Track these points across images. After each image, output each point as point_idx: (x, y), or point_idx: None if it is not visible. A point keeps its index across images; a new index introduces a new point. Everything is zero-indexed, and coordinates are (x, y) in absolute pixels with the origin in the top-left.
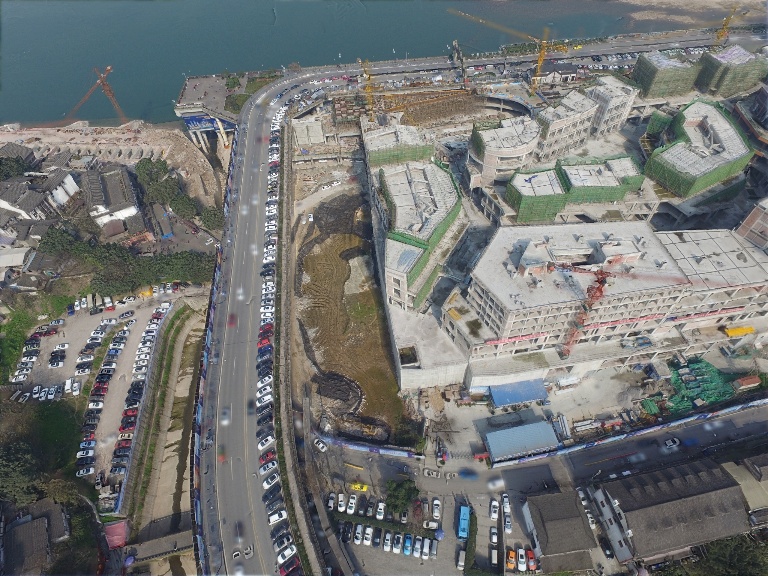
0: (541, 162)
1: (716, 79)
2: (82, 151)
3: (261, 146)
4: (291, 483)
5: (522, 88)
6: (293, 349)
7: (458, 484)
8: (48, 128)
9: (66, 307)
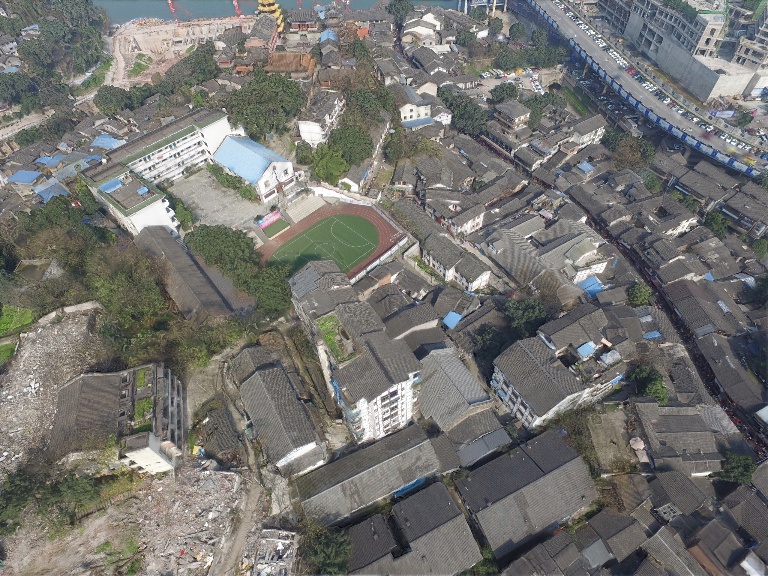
0: None
1: None
2: None
3: (547, 2)
4: None
5: None
6: None
7: (764, 124)
8: None
9: (478, 76)
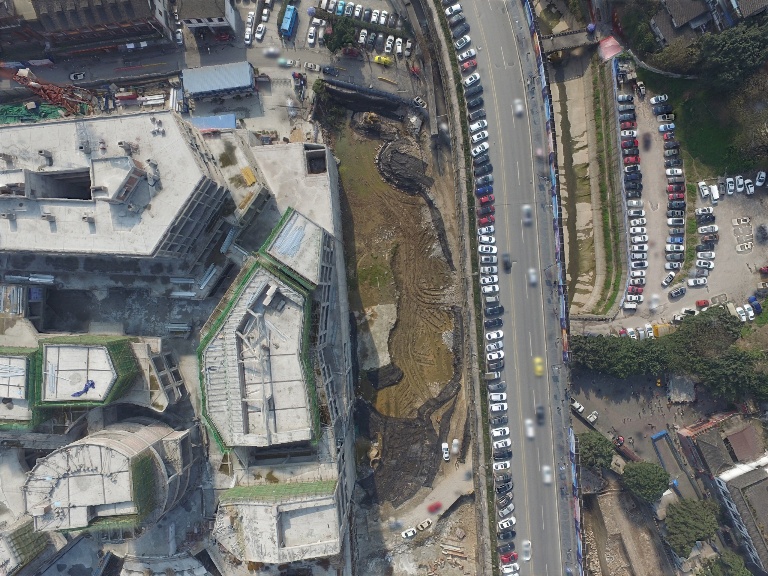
0: None
1: None
2: None
3: None
4: (443, 40)
5: None
6: None
7: (289, 57)
8: None
9: (764, 310)
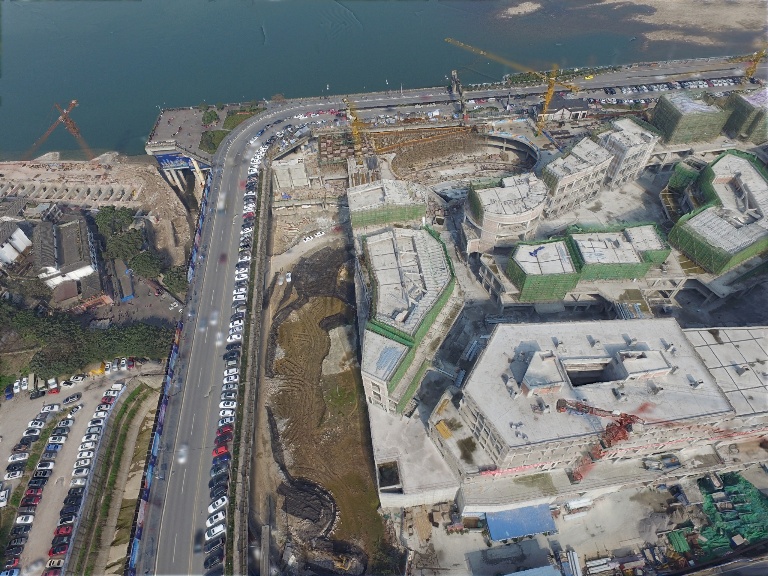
0: (548, 218)
1: (747, 124)
2: (47, 190)
3: (236, 193)
4: None
5: (527, 126)
6: (258, 448)
7: None
8: (14, 161)
9: (4, 389)
